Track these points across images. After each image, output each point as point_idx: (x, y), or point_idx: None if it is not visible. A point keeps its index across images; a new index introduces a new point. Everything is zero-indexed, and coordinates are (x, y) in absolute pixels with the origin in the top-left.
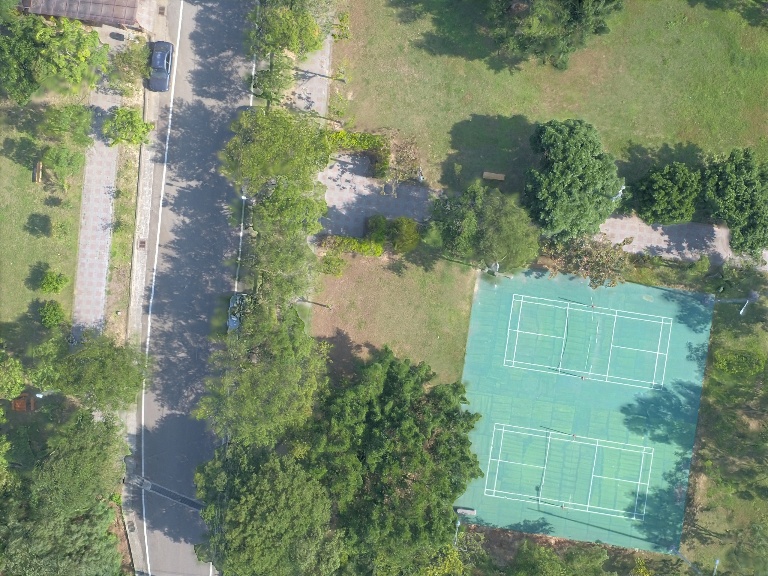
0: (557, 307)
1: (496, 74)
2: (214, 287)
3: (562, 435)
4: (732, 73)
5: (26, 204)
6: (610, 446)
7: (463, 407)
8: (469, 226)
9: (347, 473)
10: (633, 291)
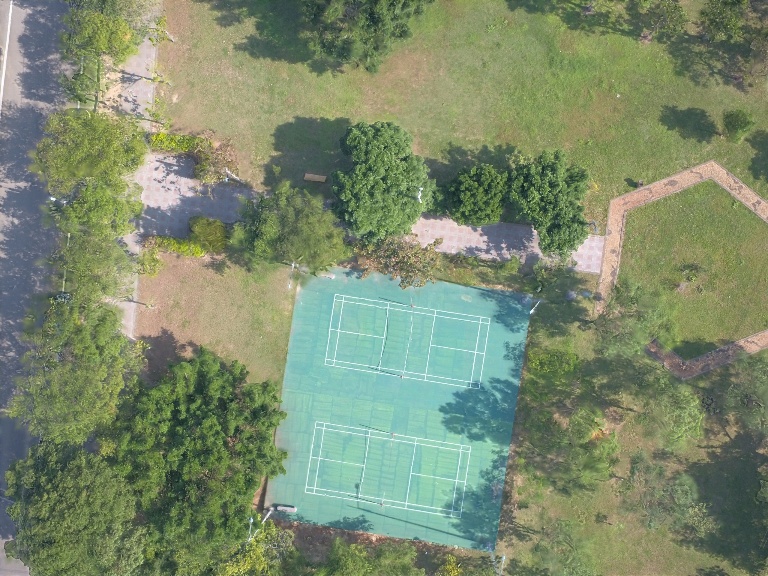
0: (377, 307)
1: (318, 77)
2: (42, 287)
3: (381, 433)
4: (551, 76)
5: None
6: (428, 444)
7: (285, 406)
8: (266, 227)
9: (149, 470)
10: (452, 291)
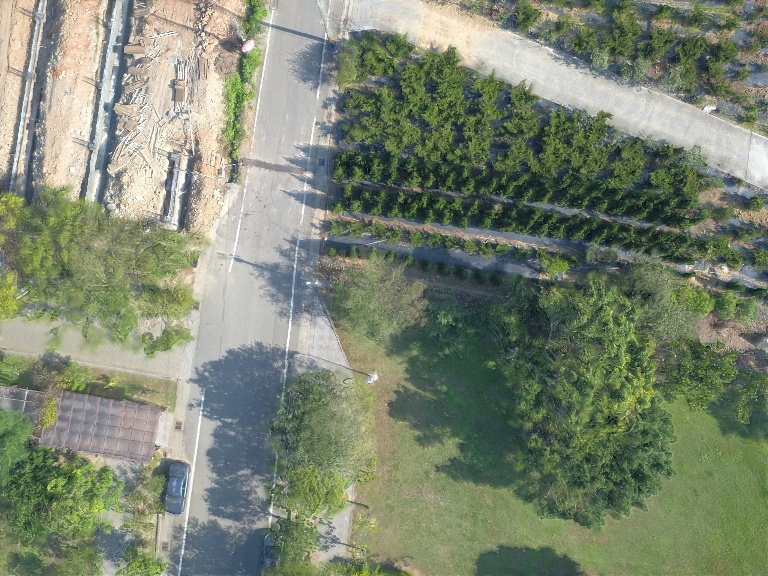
0: None
1: (525, 505)
2: None
3: None
4: (765, 510)
5: None
6: None
7: None
8: None
9: None
10: None
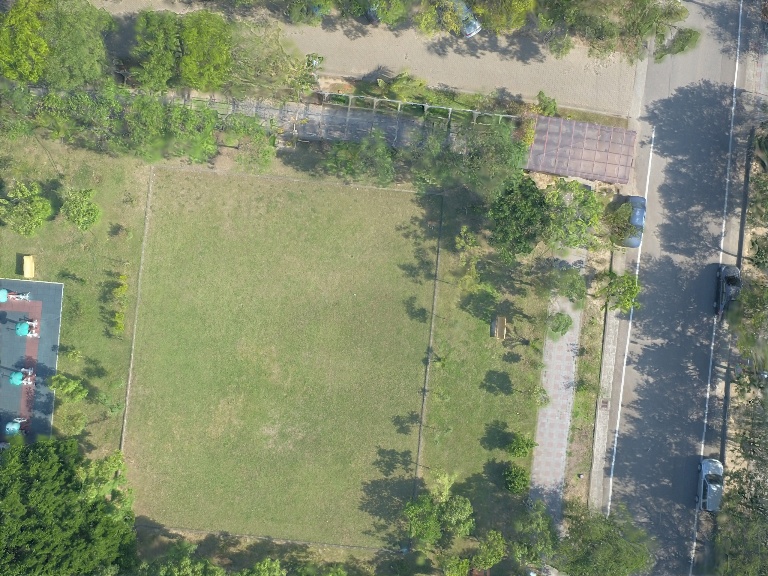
0: None
1: None
2: (678, 450)
3: None
4: None
5: (483, 359)
6: None
7: None
8: None
9: None
10: None
